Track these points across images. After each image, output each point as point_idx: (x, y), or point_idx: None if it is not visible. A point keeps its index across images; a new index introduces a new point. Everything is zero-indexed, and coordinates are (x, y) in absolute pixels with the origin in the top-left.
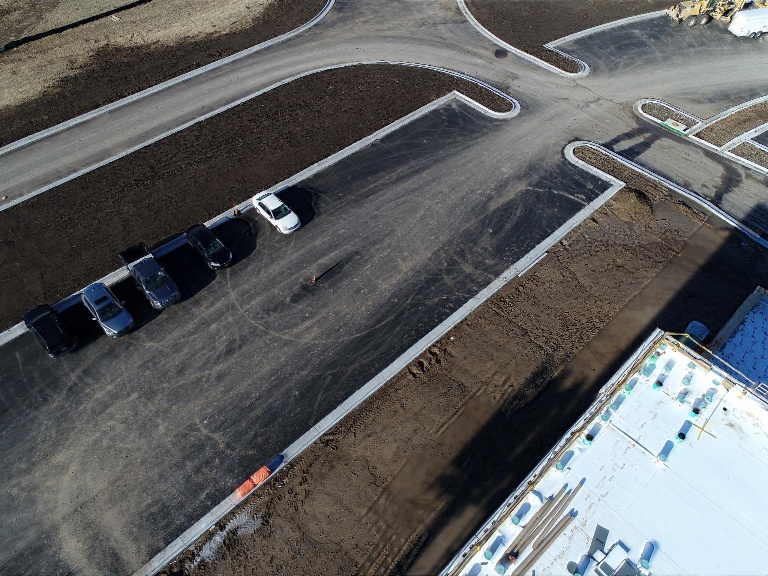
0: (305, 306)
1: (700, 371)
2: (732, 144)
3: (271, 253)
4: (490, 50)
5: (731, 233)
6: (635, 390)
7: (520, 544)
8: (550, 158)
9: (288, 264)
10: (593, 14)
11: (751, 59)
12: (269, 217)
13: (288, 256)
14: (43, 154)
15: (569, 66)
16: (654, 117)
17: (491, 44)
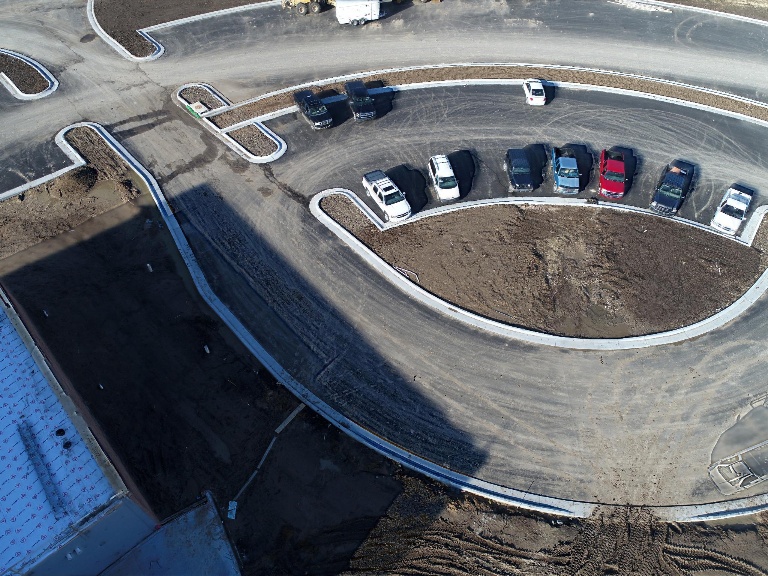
0: None
1: None
2: (238, 126)
3: None
4: (80, 34)
5: (141, 210)
6: None
7: None
8: (38, 138)
9: None
10: (215, 1)
11: (336, 46)
12: None
13: None
14: None
15: (142, 50)
16: (184, 100)
17: (87, 29)
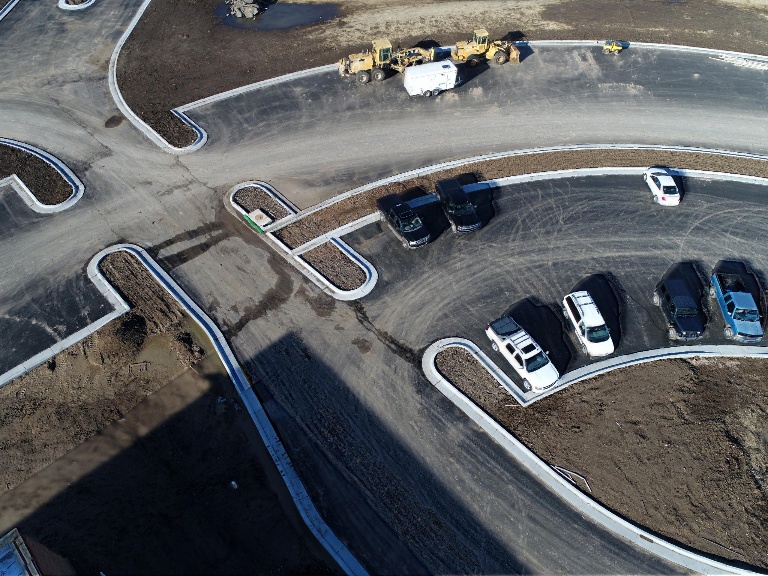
0: None
1: None
2: (311, 245)
3: None
4: (104, 117)
5: (210, 384)
6: None
7: None
8: (66, 270)
9: None
10: (259, 68)
11: (410, 125)
12: None
13: None
14: None
15: (181, 138)
16: (240, 207)
17: (111, 109)
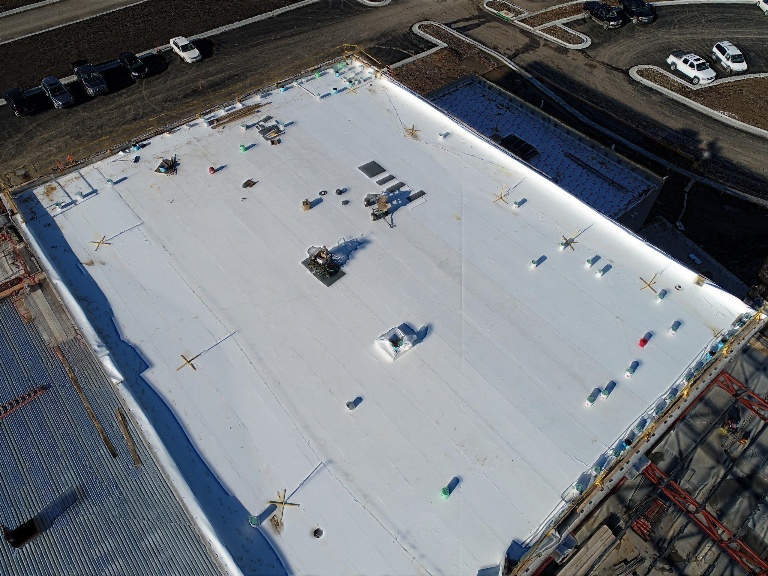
0: (191, 100)
1: (366, 70)
2: (544, 26)
3: (177, 73)
4: None
5: (510, 73)
6: (324, 76)
7: (222, 117)
8: (400, 30)
9: (187, 79)
10: None
11: None
12: (178, 50)
13: (188, 75)
14: (32, 17)
15: None
16: (493, 9)
17: None
